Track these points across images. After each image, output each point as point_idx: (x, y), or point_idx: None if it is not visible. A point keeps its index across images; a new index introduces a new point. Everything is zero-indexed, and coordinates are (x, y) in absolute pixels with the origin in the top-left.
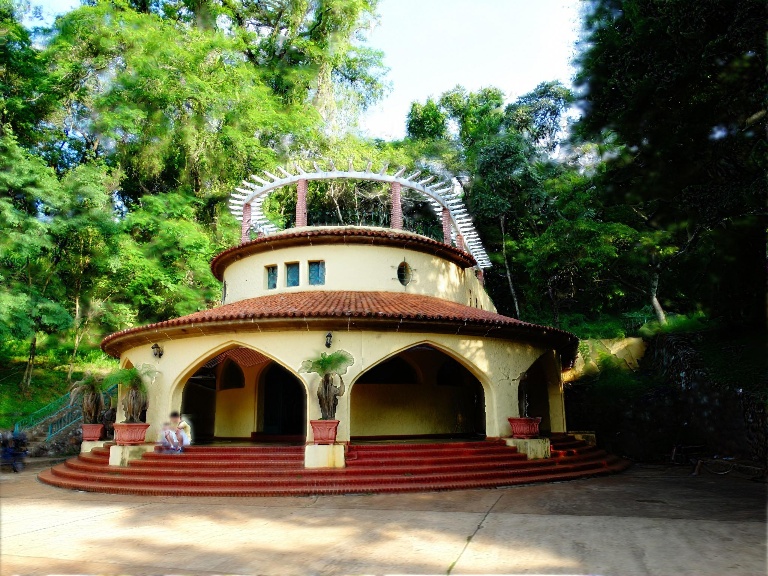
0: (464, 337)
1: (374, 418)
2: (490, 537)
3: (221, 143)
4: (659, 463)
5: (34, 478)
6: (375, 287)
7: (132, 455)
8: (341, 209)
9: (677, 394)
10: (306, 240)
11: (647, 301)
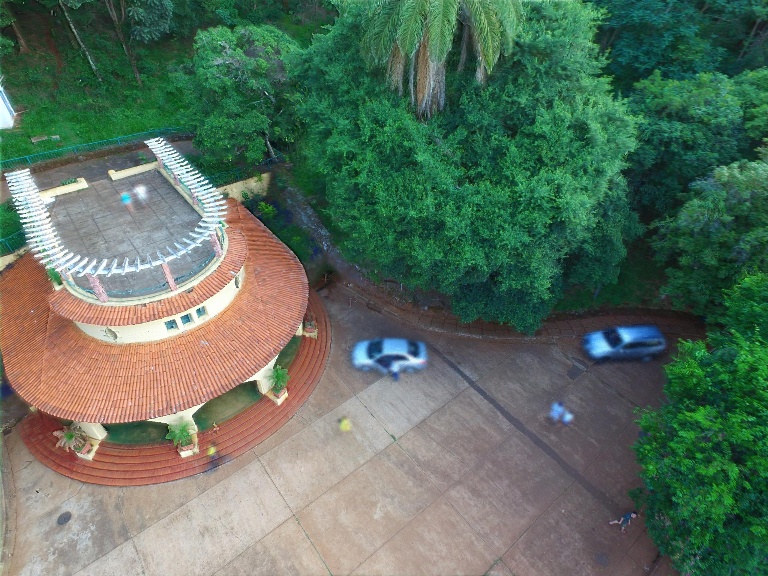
0: None
1: None
2: (375, 412)
3: None
4: (322, 285)
5: (110, 488)
6: (230, 300)
7: None
8: None
9: (323, 252)
10: None
11: (191, 33)
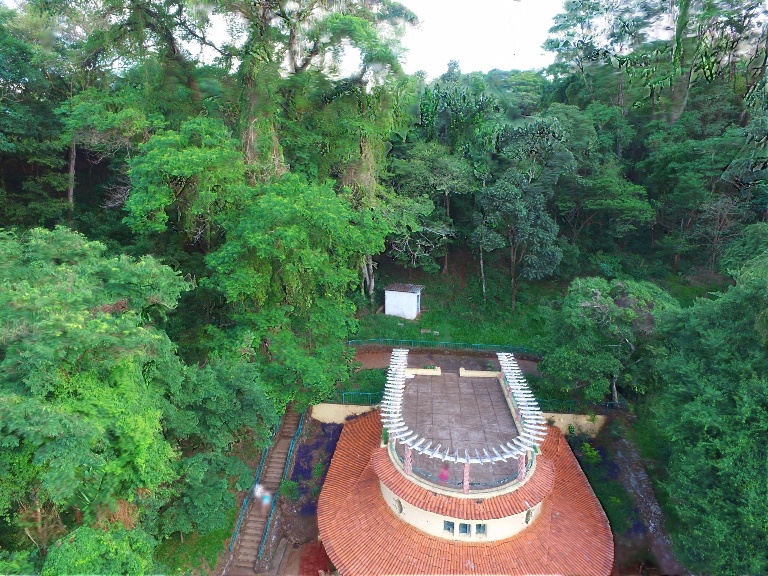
0: None
1: None
2: None
3: None
4: (633, 575)
5: None
6: (514, 532)
7: None
8: None
9: (646, 532)
10: None
11: (571, 277)
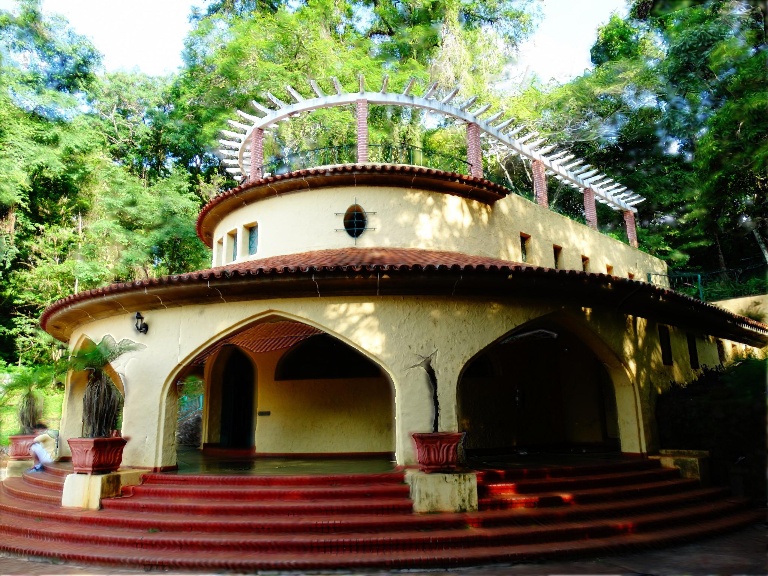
0: (336, 299)
1: (306, 428)
2: None
3: (320, 127)
4: None
5: None
6: (313, 245)
7: (12, 472)
8: (511, 174)
9: None
10: (238, 200)
11: None
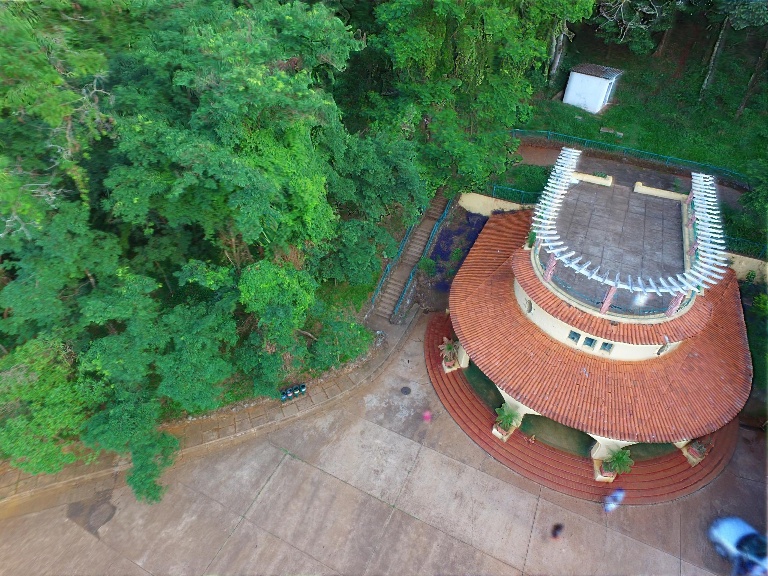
0: None
1: None
2: None
3: None
4: (754, 425)
5: (439, 401)
6: (640, 359)
7: None
8: None
9: None
10: None
11: None
